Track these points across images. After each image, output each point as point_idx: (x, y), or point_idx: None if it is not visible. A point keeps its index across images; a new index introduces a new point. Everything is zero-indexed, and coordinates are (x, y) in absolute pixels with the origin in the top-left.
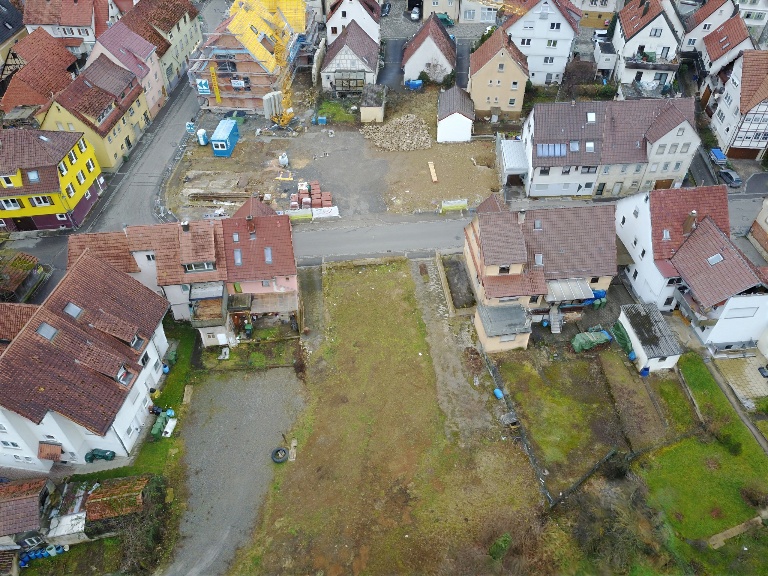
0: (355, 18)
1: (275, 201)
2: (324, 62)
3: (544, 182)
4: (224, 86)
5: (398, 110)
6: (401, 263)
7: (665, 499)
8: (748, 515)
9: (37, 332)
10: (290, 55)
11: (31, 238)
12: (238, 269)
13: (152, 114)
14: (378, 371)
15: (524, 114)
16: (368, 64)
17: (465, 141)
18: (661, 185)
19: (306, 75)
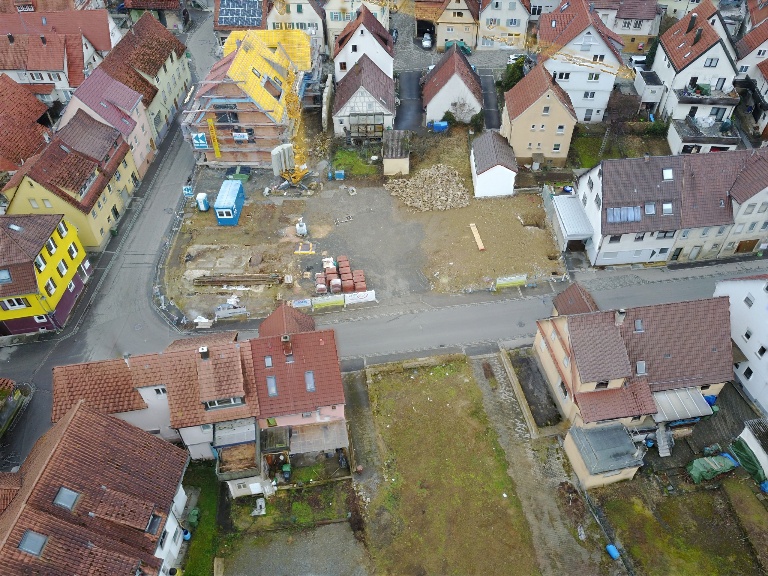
0: (367, 52)
1: (297, 283)
2: (335, 104)
3: (613, 250)
4: (224, 139)
5: (425, 159)
6: (460, 363)
7: None
8: None
9: (20, 548)
10: None
11: (4, 347)
12: (272, 401)
13: (140, 173)
14: (456, 524)
15: (568, 159)
16: (386, 106)
17: (507, 195)
18: (744, 246)
19: (313, 117)
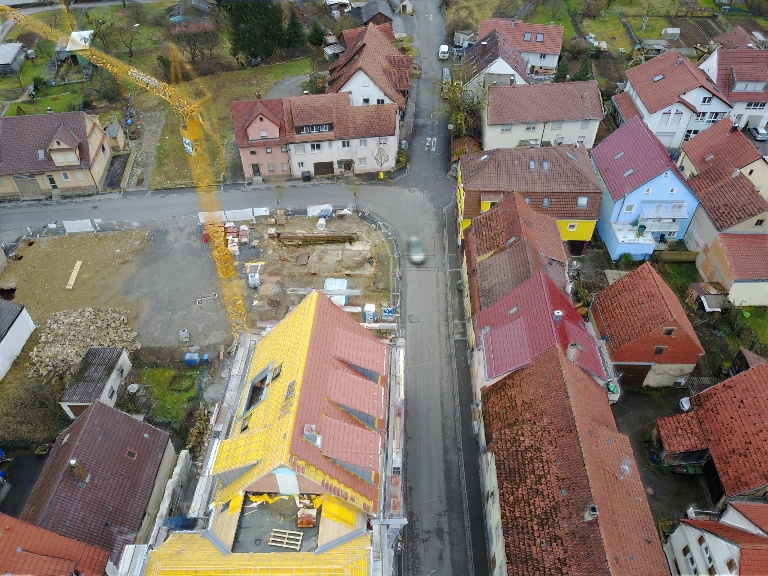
0: None
1: (265, 236)
2: (154, 473)
3: None
4: None
5: (59, 389)
6: None
7: (75, 102)
8: (42, 99)
9: (361, 40)
10: None
11: None
12: None
13: None
14: None
15: None
16: None
17: None
18: None
19: None
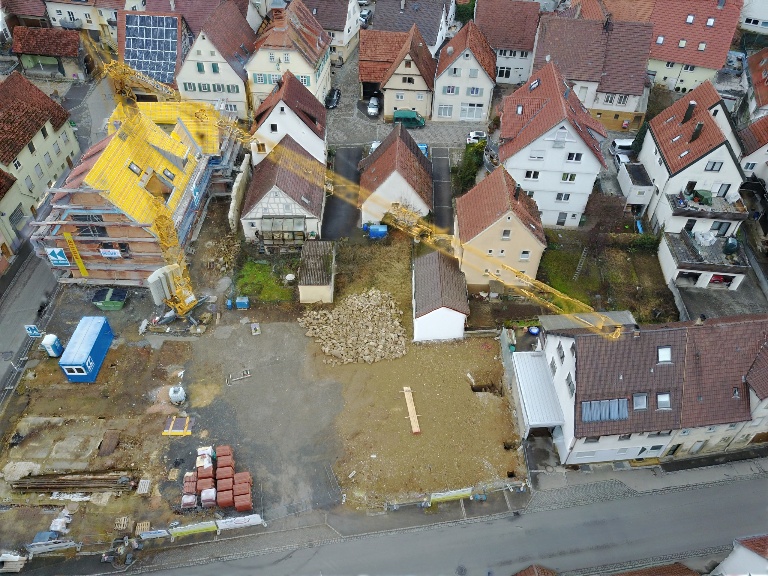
0: (290, 132)
1: (158, 489)
2: (246, 199)
3: (590, 449)
4: (90, 255)
5: (355, 279)
6: None
7: None
8: None
9: None
10: (194, 198)
11: None
12: None
13: None
14: None
15: None
16: (309, 206)
17: (455, 339)
18: (761, 436)
19: (224, 208)
